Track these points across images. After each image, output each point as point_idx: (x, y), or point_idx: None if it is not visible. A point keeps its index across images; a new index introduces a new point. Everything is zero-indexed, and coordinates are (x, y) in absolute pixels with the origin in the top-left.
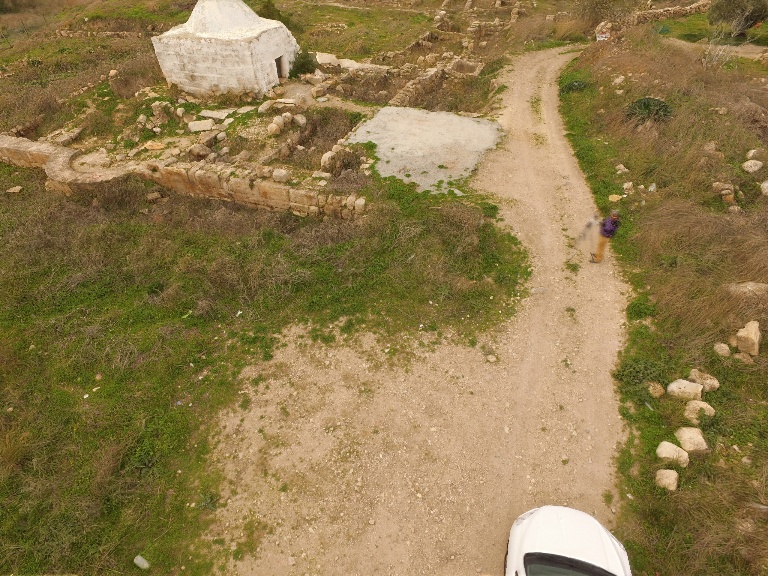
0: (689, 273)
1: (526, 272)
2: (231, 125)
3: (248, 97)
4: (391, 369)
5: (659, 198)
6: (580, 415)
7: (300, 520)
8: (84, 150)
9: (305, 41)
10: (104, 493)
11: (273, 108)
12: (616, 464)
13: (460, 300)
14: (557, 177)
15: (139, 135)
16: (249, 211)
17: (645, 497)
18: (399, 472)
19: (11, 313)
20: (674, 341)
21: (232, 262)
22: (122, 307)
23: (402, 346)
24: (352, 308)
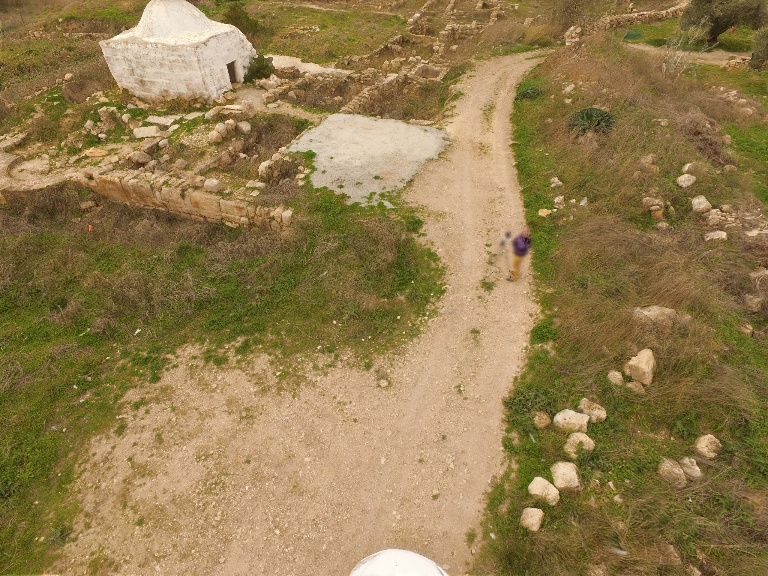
0: (595, 295)
1: (440, 290)
2: (175, 132)
3: (197, 103)
4: (278, 394)
5: (587, 213)
6: (461, 446)
7: (149, 557)
8: (26, 156)
9: (274, 44)
10: None
11: (219, 115)
12: (487, 500)
13: (365, 320)
14: (493, 189)
15: (83, 141)
16: (182, 221)
17: (507, 537)
18: (262, 506)
19: None
20: (570, 367)
21: (143, 277)
22: (22, 323)
23: (295, 369)
24: (252, 328)
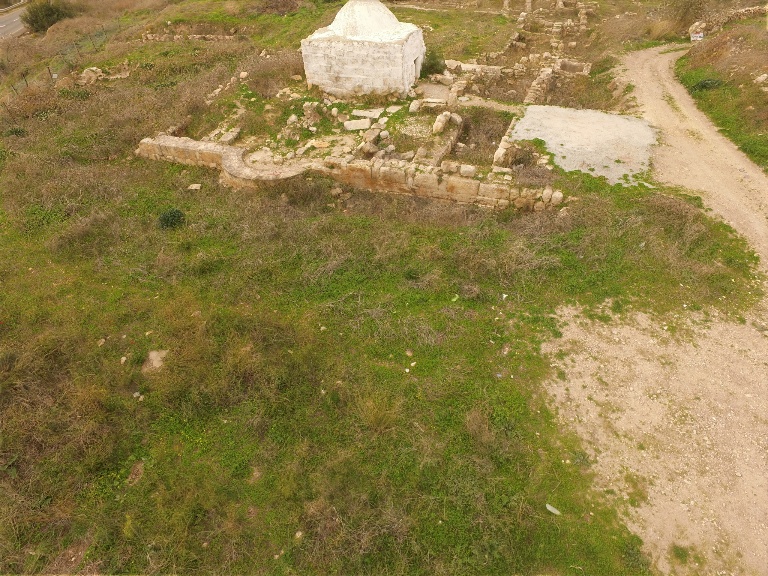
0: None
1: (753, 257)
2: (388, 124)
3: (393, 97)
4: (679, 344)
5: None
6: None
7: (672, 473)
8: (249, 149)
9: None
10: (488, 451)
11: (426, 107)
12: None
13: (706, 283)
14: (733, 170)
15: (299, 134)
16: None
17: None
18: (739, 432)
19: (285, 298)
20: None
21: None
22: (387, 292)
23: (678, 324)
24: (613, 290)
